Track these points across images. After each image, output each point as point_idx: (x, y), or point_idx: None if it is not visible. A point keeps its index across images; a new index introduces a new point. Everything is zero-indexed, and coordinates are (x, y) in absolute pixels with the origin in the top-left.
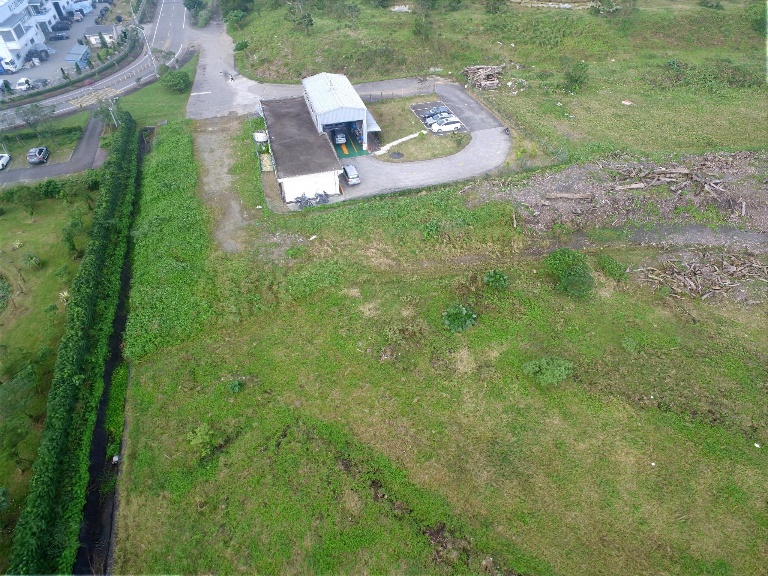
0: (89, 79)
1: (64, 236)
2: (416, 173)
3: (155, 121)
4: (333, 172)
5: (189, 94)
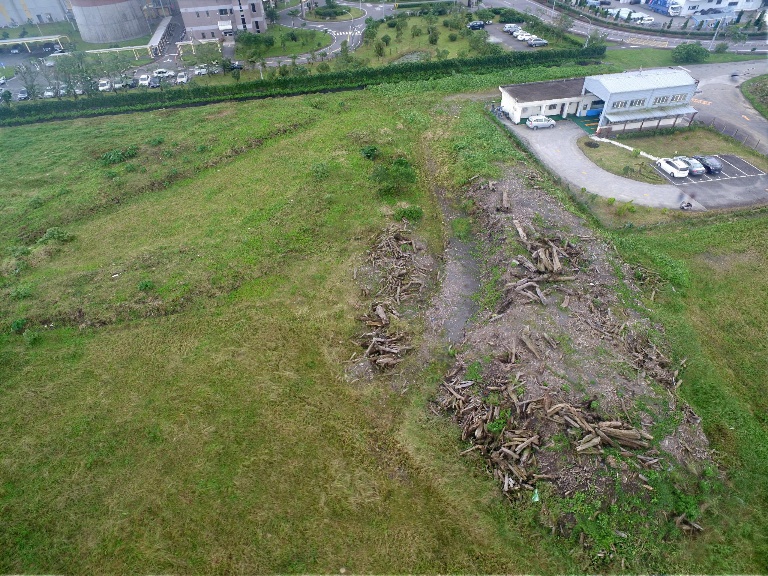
0: (682, 35)
1: (437, 53)
2: (558, 151)
3: (612, 62)
4: (514, 101)
5: (678, 65)
